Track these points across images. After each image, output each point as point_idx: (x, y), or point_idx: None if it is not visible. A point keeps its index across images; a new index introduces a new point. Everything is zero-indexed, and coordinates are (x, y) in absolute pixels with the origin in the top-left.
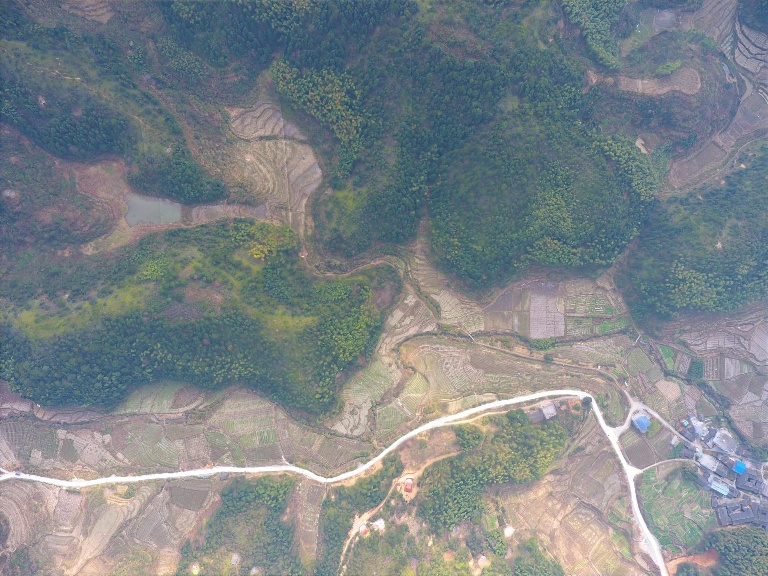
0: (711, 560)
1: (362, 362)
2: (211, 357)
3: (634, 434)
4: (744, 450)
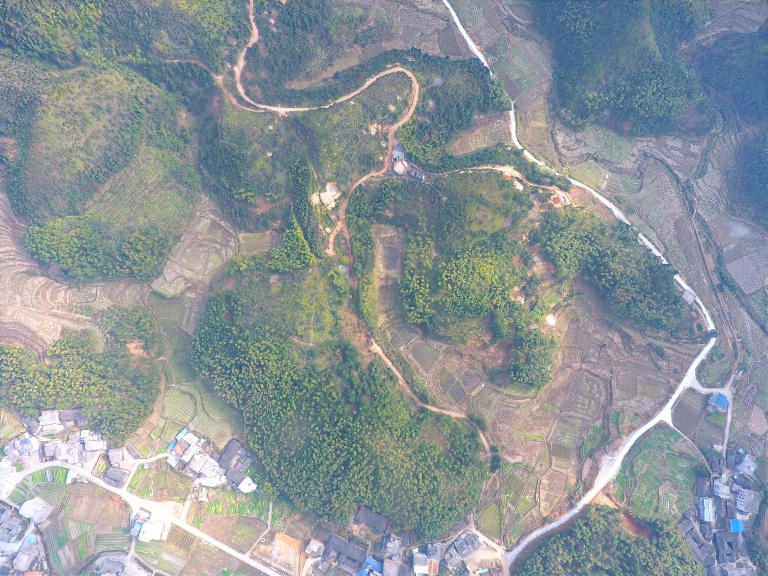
0: (635, 534)
1: (626, 128)
2: (582, 0)
3: (700, 402)
4: (750, 528)
